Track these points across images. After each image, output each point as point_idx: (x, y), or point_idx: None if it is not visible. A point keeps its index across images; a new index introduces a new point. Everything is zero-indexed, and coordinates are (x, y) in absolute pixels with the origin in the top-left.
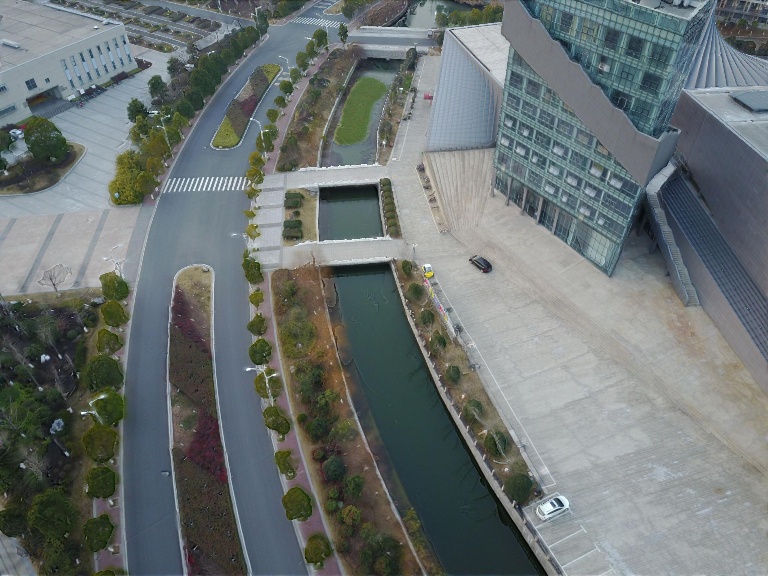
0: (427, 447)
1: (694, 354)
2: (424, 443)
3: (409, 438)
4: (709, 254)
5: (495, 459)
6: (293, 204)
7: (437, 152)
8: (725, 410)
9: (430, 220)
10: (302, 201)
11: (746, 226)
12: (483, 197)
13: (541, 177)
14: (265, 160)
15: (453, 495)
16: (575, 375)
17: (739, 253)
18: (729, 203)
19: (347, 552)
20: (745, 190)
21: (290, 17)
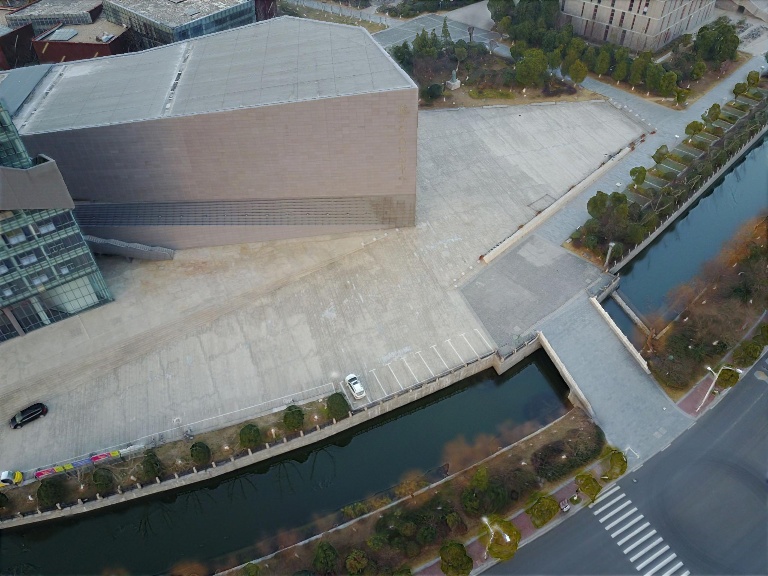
0: (255, 513)
1: (225, 267)
2: (250, 515)
3: (247, 526)
4: (137, 218)
5: (303, 426)
6: None
7: None
8: (283, 264)
9: None
10: None
11: (134, 179)
12: None
13: None
14: None
15: (308, 494)
16: (223, 351)
17: (150, 199)
18: (100, 180)
19: (392, 568)
20: (104, 159)
21: None
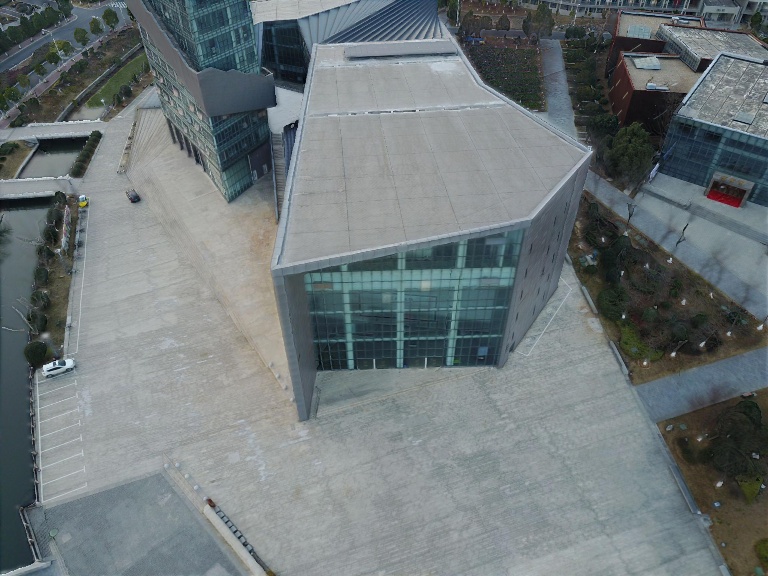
0: (28, 339)
1: (257, 259)
2: (26, 336)
3: (8, 330)
4: None
5: (40, 336)
6: (2, 152)
7: (151, 109)
8: (251, 298)
9: (116, 163)
10: (15, 150)
11: None
12: (167, 144)
13: (180, 119)
14: (3, 118)
15: None
16: (151, 276)
17: None
18: None
19: None
20: None
21: (107, 2)
